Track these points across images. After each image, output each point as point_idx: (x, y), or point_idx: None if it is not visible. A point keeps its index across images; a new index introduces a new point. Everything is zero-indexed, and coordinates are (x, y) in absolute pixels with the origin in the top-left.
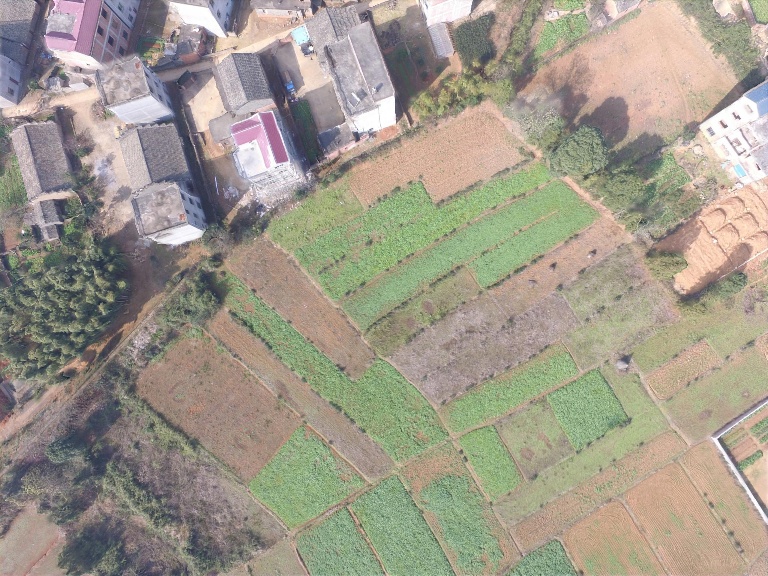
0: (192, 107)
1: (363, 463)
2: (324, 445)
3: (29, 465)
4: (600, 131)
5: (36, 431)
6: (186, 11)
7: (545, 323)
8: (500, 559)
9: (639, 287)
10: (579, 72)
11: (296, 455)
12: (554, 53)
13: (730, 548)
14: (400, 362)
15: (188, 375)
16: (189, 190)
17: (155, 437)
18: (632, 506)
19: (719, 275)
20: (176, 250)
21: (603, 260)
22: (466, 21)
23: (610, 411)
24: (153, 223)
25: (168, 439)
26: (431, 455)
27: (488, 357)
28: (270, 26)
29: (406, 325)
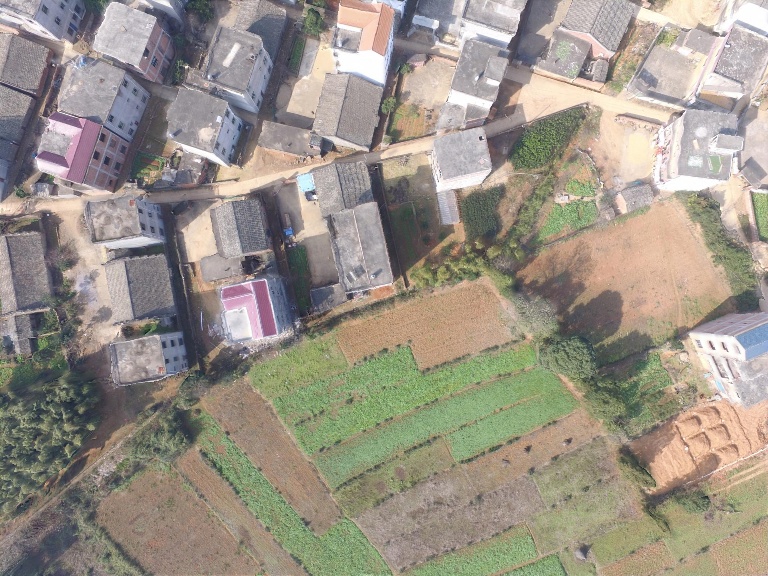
0: (185, 235)
1: None
2: None
3: None
4: (591, 347)
5: None
6: (189, 147)
7: (512, 504)
8: None
9: (608, 480)
10: (581, 260)
11: None
12: (559, 237)
13: None
14: (365, 524)
15: (151, 508)
16: (172, 323)
17: (110, 567)
18: None
19: (685, 481)
20: None
21: (577, 449)
22: (476, 189)
23: None
24: (130, 372)
25: (123, 572)
26: None
27: (452, 530)
28: (276, 162)
29: (376, 488)
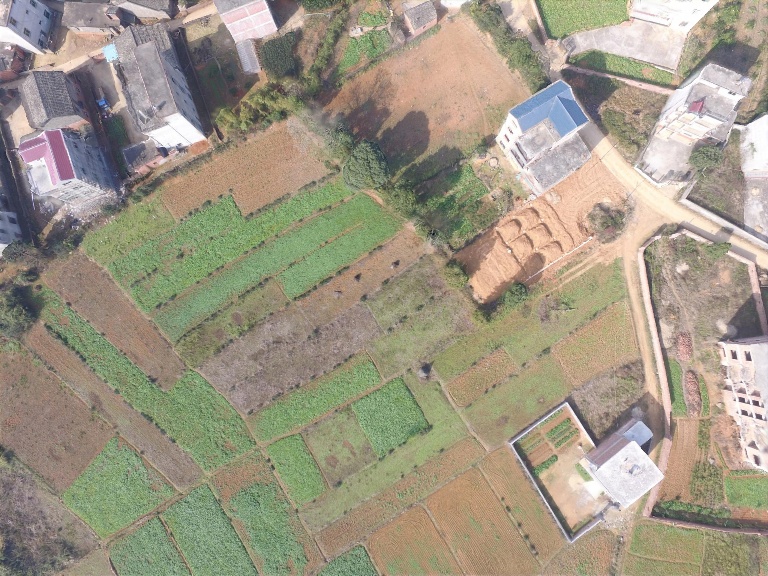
0: (11, 123)
1: (173, 473)
2: (136, 455)
3: None
4: (376, 146)
5: None
6: None
7: (350, 333)
8: (304, 565)
9: (440, 297)
10: (382, 87)
11: (109, 466)
12: (358, 68)
13: (525, 551)
14: (209, 373)
15: (5, 388)
16: (4, 205)
17: None
18: (433, 511)
19: (514, 284)
20: None
21: (406, 271)
22: (275, 37)
23: (411, 418)
24: None
25: None
26: (240, 464)
27: (295, 367)
28: (87, 43)
29: (215, 336)
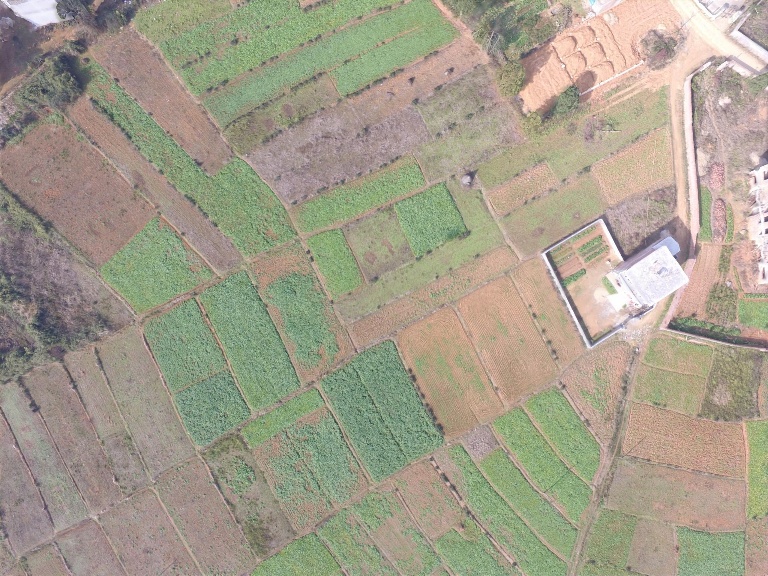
0: None
1: (213, 256)
2: (177, 237)
3: None
4: None
5: None
6: None
7: (399, 135)
8: (335, 353)
9: (490, 107)
10: None
11: (148, 244)
12: None
13: (546, 355)
14: (256, 161)
15: (46, 160)
16: None
17: (9, 218)
18: (463, 313)
19: None
20: (40, 32)
21: (459, 79)
22: None
23: (451, 222)
24: None
25: (21, 219)
26: (280, 254)
27: (341, 163)
28: None
29: (265, 126)
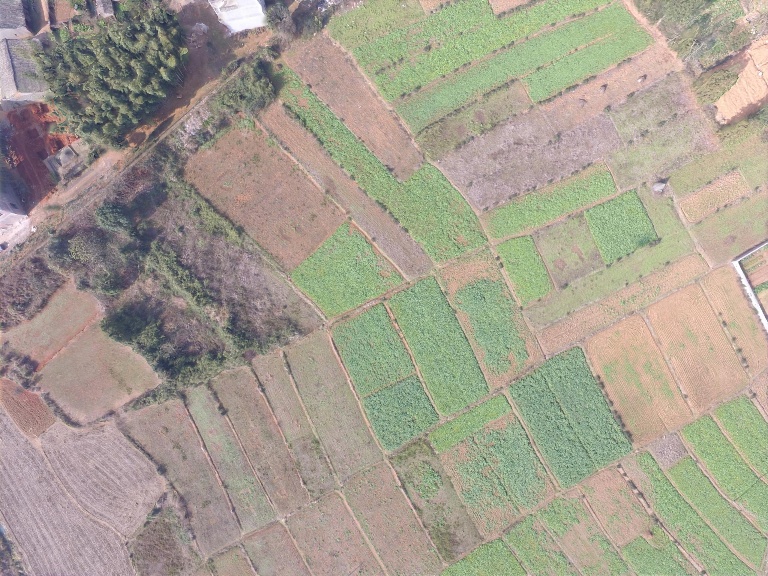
0: None
1: (403, 261)
2: (367, 242)
3: (75, 233)
4: None
5: (82, 204)
6: None
7: (590, 142)
8: (525, 359)
9: (683, 115)
10: None
11: (339, 249)
12: None
13: (736, 363)
14: (448, 167)
15: (237, 165)
16: None
17: (200, 222)
18: (652, 320)
19: (760, 108)
20: (234, 38)
21: (652, 86)
22: None
23: (642, 230)
24: None
25: (214, 224)
26: (469, 260)
27: (533, 170)
28: None
29: (457, 132)
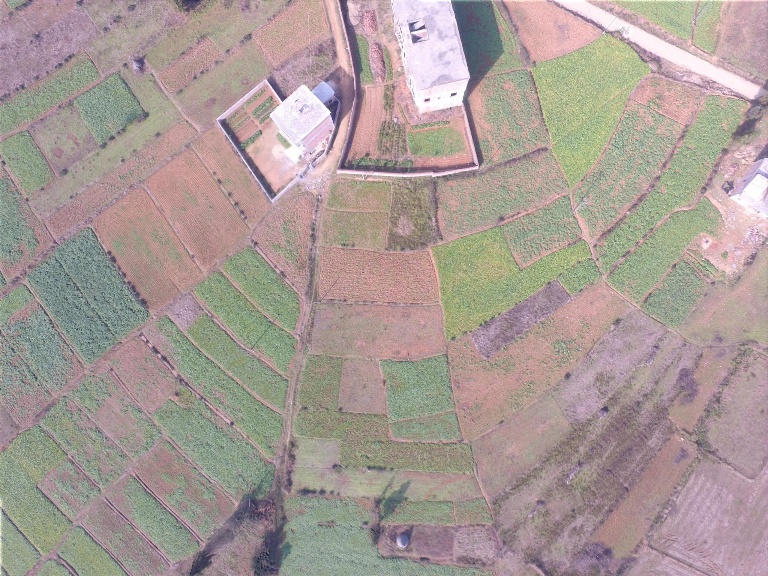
0: None
1: None
2: None
3: None
4: None
5: None
6: None
7: (69, 35)
8: (35, 246)
9: None
10: None
11: None
12: None
13: (236, 217)
14: None
15: None
16: None
17: None
18: (152, 190)
19: None
20: None
21: None
22: None
23: (128, 107)
24: None
25: None
26: None
27: (19, 70)
28: None
29: None
